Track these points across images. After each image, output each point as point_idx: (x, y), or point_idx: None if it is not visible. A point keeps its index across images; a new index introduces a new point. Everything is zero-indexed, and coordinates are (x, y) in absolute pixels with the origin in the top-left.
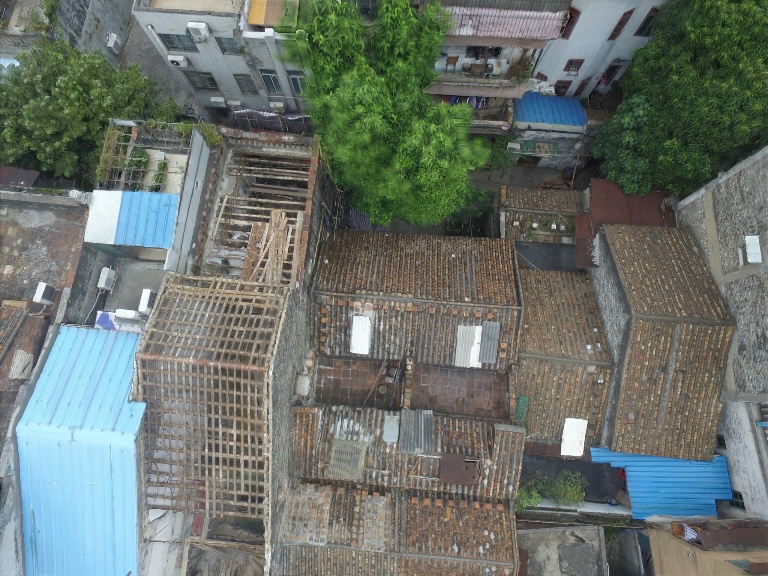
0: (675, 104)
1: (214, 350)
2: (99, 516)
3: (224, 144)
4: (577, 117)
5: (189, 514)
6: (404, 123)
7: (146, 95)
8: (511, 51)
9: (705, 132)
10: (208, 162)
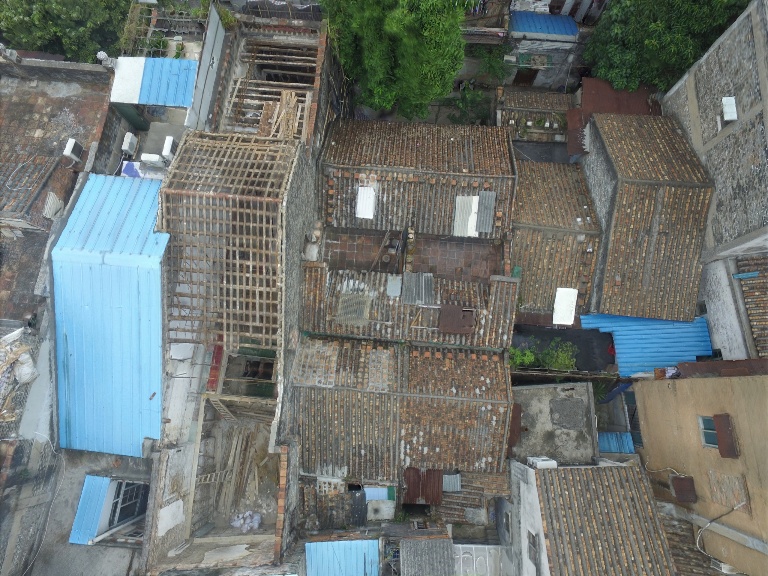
0: None
1: (232, 186)
2: (127, 338)
3: (238, 30)
4: (570, 30)
5: (205, 372)
6: None
7: None
8: None
9: (686, 10)
10: (223, 43)
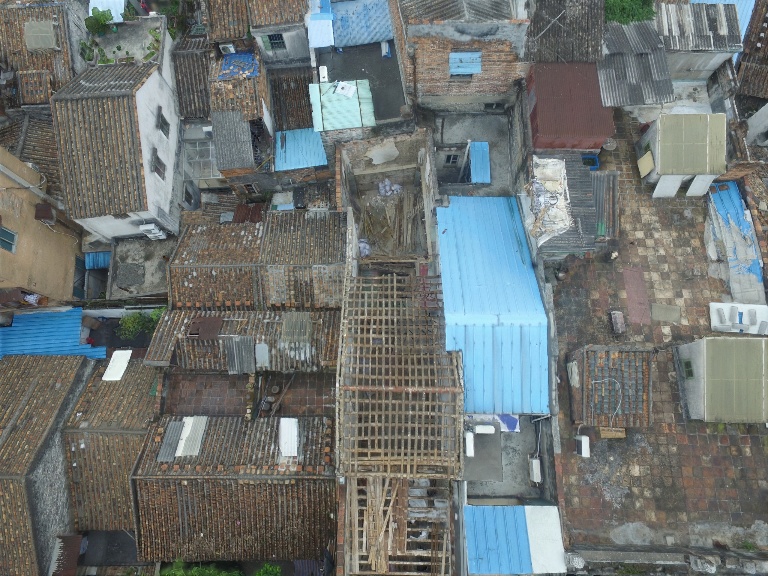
0: None
1: (392, 401)
2: (471, 265)
3: None
4: None
5: None
6: None
7: None
8: None
9: None
10: None
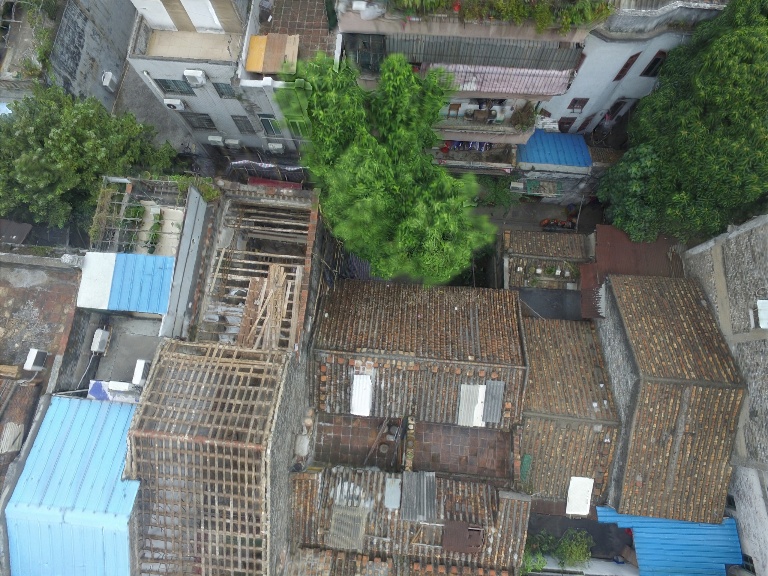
0: (684, 159)
1: (210, 426)
2: None
3: (221, 196)
4: (581, 156)
5: None
6: (406, 193)
7: (142, 140)
8: (515, 99)
9: (715, 188)
10: (205, 217)
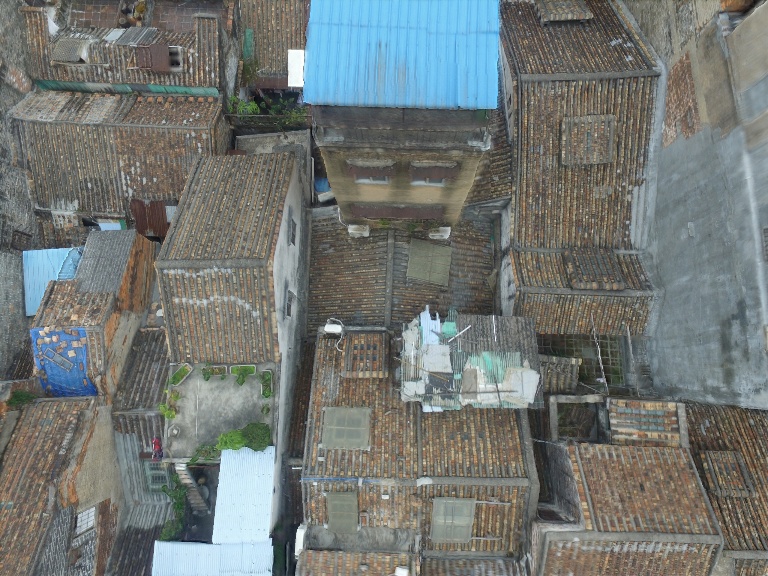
0: None
1: None
2: None
3: None
4: None
5: None
6: None
7: None
8: None
9: None
10: None
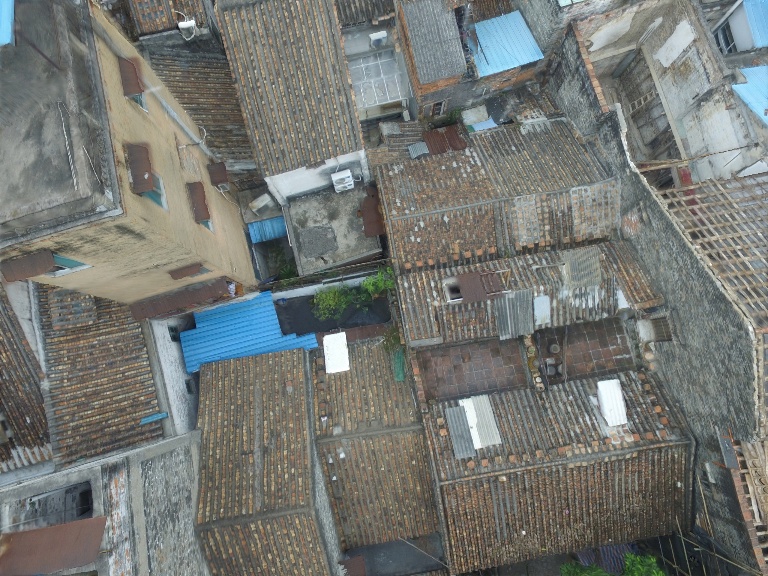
0: None
1: None
2: None
3: None
4: None
5: None
6: None
7: None
8: None
9: None
10: None
